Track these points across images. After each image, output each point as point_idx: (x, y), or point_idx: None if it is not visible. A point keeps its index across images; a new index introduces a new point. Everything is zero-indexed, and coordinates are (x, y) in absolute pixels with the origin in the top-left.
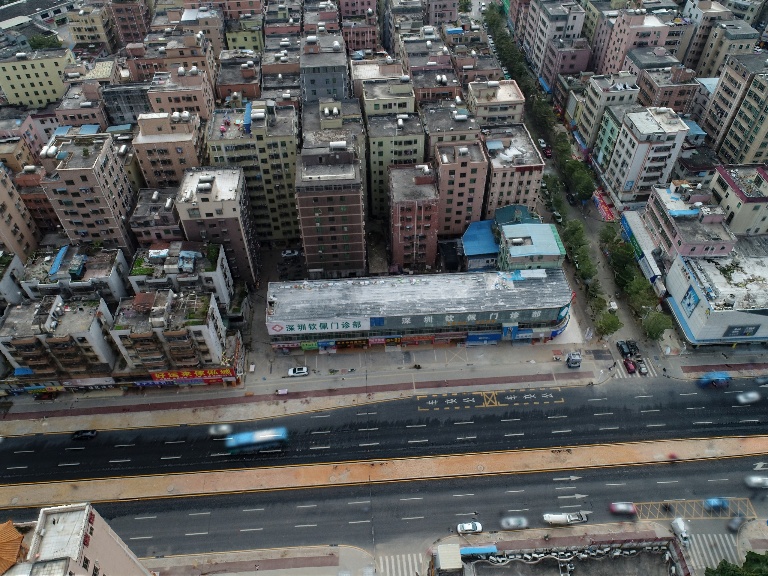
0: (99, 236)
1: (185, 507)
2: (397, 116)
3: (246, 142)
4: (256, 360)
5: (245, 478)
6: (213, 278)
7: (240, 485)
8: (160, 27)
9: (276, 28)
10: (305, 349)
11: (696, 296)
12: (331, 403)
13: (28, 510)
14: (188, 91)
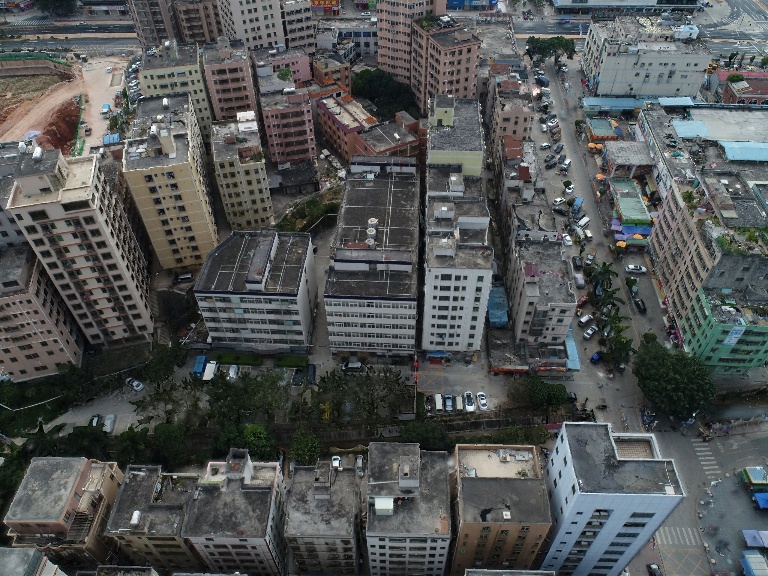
0: None
1: None
2: None
3: None
4: (346, 11)
5: None
6: None
7: None
8: None
9: None
10: (369, 9)
11: None
12: None
13: None
14: None
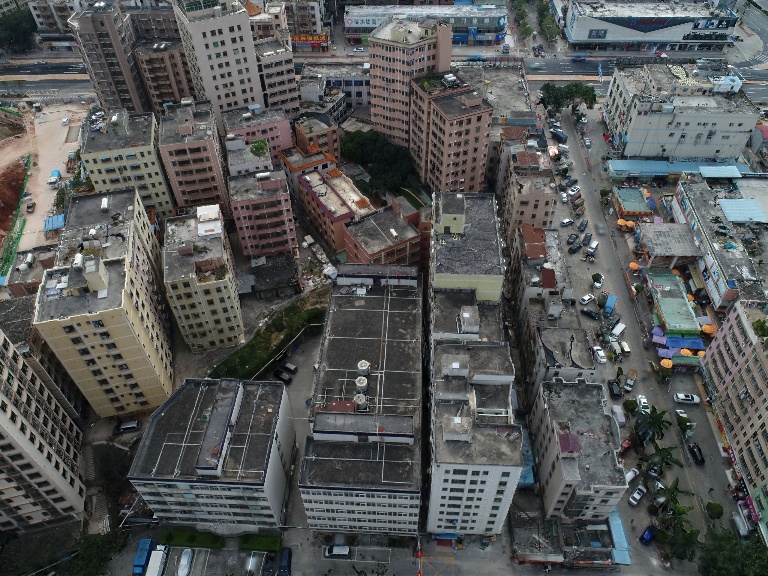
0: None
1: None
2: None
3: None
4: (336, 47)
5: None
6: None
7: None
8: None
9: None
10: (363, 44)
11: (574, 15)
12: None
13: None
14: None
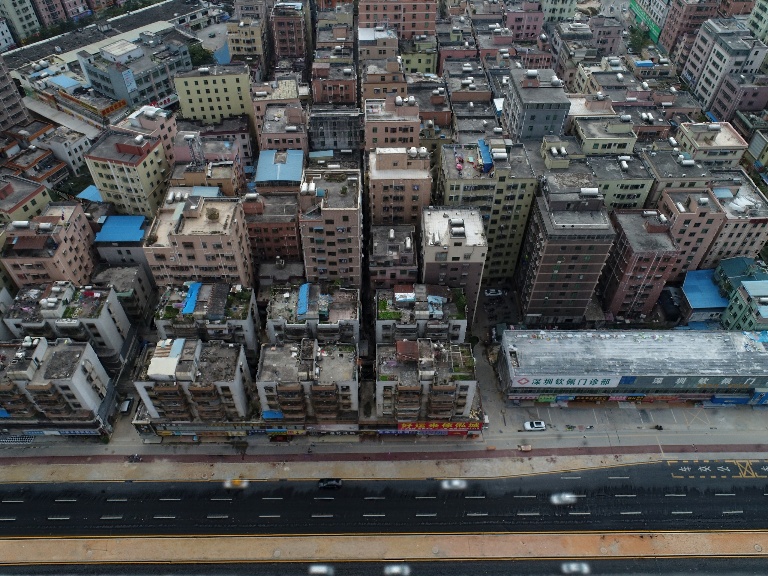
0: (336, 274)
1: (455, 572)
2: (619, 157)
3: (487, 183)
4: (487, 410)
5: (511, 543)
6: (461, 326)
7: (507, 551)
8: (326, 44)
9: (453, 51)
10: None
11: None
12: (579, 463)
13: (293, 565)
14: (407, 122)
